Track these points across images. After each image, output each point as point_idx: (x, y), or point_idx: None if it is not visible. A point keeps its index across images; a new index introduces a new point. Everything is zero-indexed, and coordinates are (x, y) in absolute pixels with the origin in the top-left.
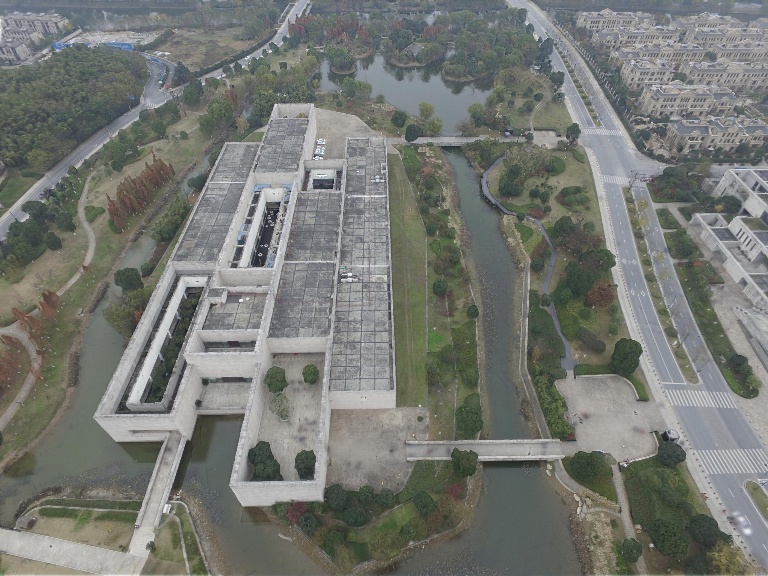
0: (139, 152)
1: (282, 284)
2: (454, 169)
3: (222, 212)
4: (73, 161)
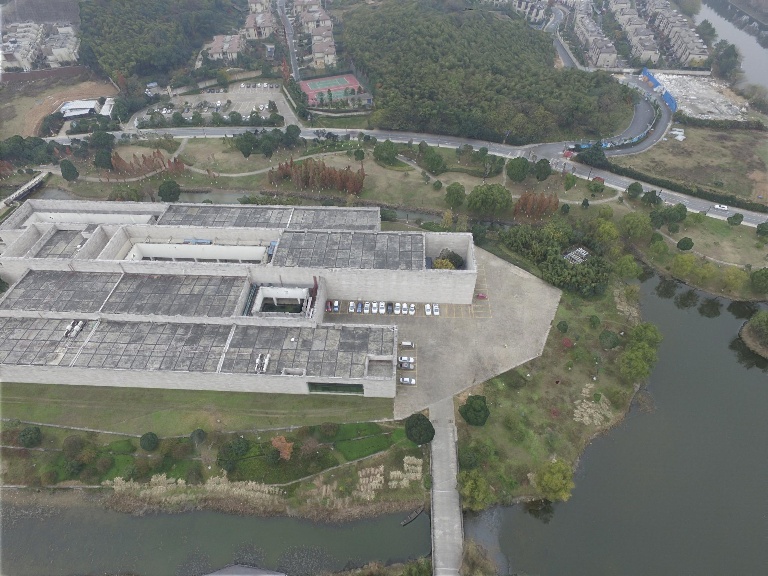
0: (399, 164)
1: (94, 274)
2: (342, 523)
3: (235, 224)
4: (395, 137)
